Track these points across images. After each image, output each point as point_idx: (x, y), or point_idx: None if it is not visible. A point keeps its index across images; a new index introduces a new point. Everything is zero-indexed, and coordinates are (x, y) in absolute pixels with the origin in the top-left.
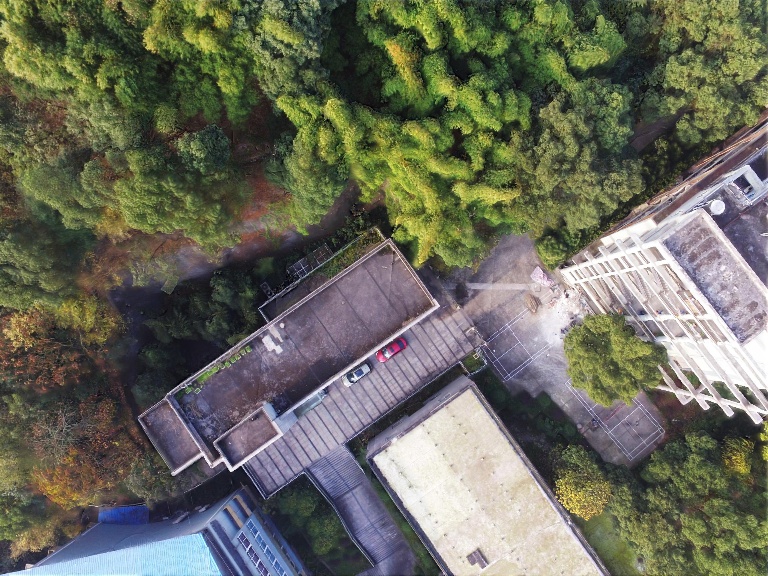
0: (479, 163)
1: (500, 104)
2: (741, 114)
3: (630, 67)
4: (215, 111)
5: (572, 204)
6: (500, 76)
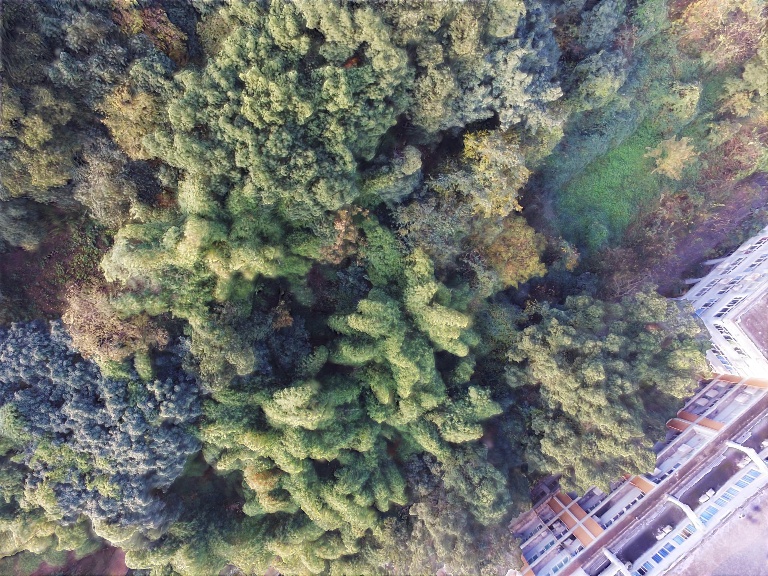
0: (353, 551)
1: (369, 500)
2: (622, 472)
3: (518, 390)
4: (60, 561)
5: (454, 575)
6: (369, 467)
